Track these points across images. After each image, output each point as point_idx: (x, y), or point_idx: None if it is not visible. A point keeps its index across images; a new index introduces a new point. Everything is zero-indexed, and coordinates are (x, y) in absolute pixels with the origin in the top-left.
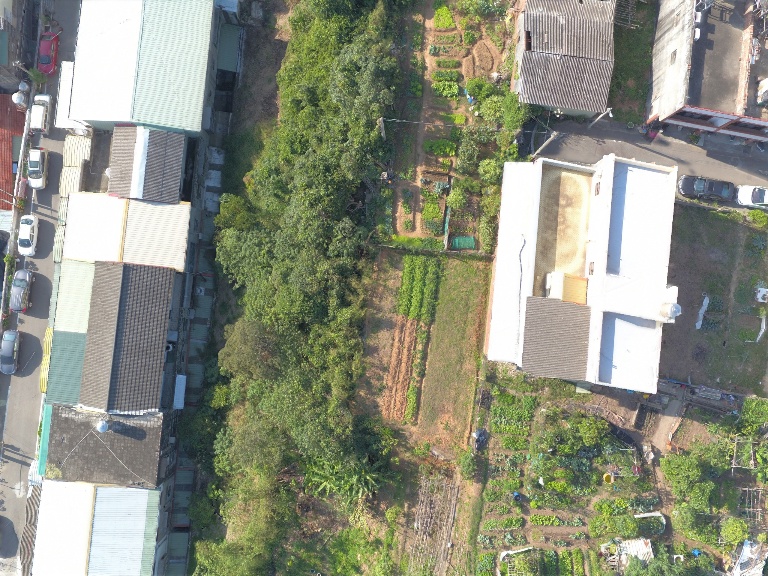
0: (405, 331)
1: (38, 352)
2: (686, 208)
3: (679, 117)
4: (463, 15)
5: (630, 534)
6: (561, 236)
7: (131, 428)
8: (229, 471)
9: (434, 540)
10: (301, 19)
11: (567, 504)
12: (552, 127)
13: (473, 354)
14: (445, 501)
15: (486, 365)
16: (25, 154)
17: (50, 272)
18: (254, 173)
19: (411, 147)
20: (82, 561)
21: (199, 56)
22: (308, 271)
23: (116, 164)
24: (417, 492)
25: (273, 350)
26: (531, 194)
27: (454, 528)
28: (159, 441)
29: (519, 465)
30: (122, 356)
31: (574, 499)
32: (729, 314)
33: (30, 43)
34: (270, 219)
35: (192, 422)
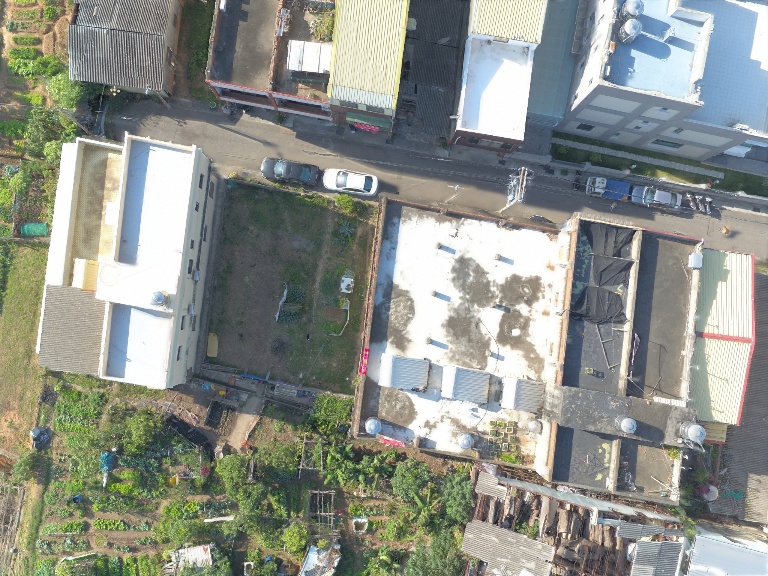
0: None
1: None
2: (271, 193)
3: (238, 95)
4: None
5: (181, 539)
6: None
7: None
8: None
9: None
10: None
11: (130, 507)
12: (129, 107)
13: None
14: (10, 503)
15: None
16: None
17: None
18: None
19: None
20: None
21: None
22: None
23: None
24: None
25: None
26: None
27: (19, 532)
28: None
29: None
30: None
31: (142, 502)
32: (314, 305)
33: None
34: None
35: None
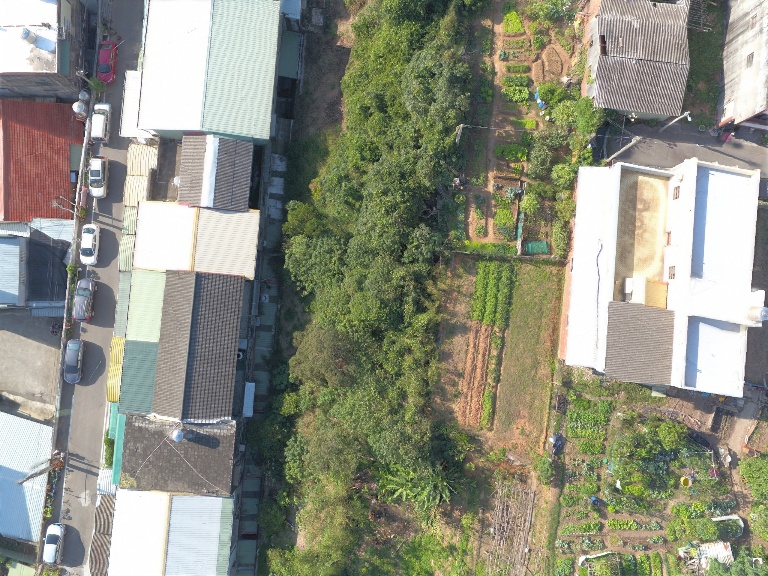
0: (479, 337)
1: (101, 361)
2: (759, 210)
3: (755, 120)
4: (532, 20)
5: (711, 537)
6: (639, 240)
7: (204, 436)
8: (300, 478)
9: (509, 545)
10: (365, 25)
11: (645, 508)
12: None
13: (547, 359)
14: (521, 506)
15: (561, 370)
16: (85, 163)
17: (112, 281)
18: (323, 180)
19: (482, 153)
20: (158, 570)
21: (267, 64)
22: (384, 278)
23: (186, 173)
24: (491, 497)
25: (347, 357)
26: (608, 199)
27: (531, 533)
28: (233, 449)
29: (596, 469)
30: (195, 365)
31: (651, 503)
32: None
33: (87, 52)
34: (339, 226)
35: (262, 430)
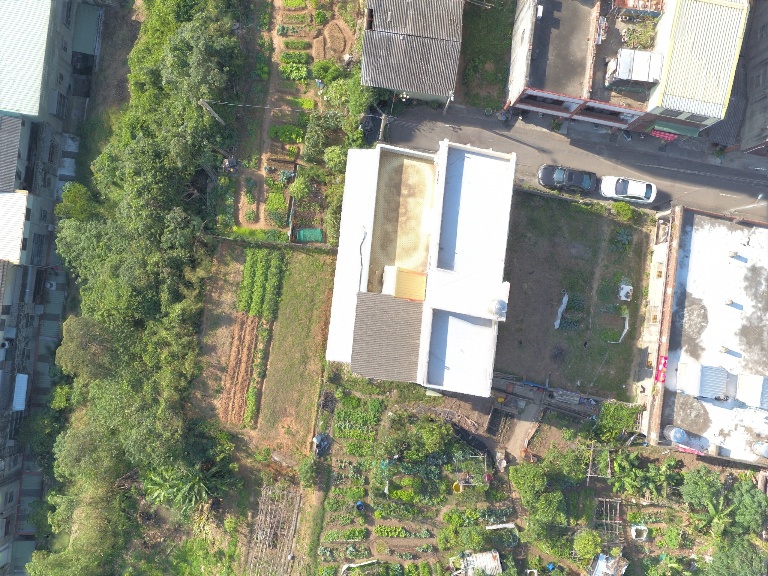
0: (246, 329)
1: None
2: (547, 200)
3: (531, 102)
4: None
5: (475, 547)
6: (402, 228)
7: None
8: (68, 476)
9: None
10: None
11: (413, 514)
12: (404, 113)
13: (318, 354)
14: (286, 510)
15: (330, 365)
16: None
17: None
18: None
19: (255, 133)
20: None
21: (37, 35)
22: (138, 264)
23: None
24: None
25: (105, 348)
26: None
27: (295, 539)
28: None
29: (364, 472)
30: None
31: (422, 509)
32: (591, 313)
33: None
34: None
35: (31, 424)
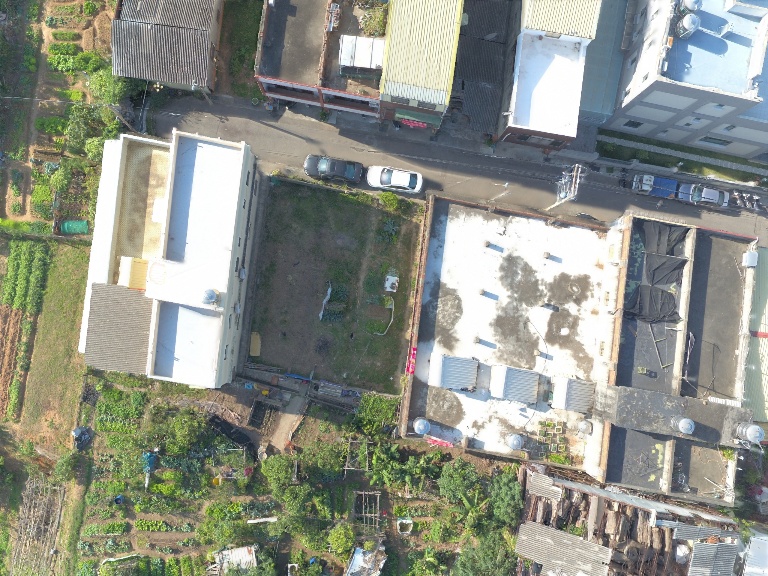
0: (10, 322)
1: None
2: (314, 190)
3: (283, 91)
4: None
5: (226, 541)
6: (150, 219)
7: None
8: None
9: None
10: None
11: (173, 508)
12: (170, 103)
13: None
14: (50, 504)
15: None
16: None
17: None
18: None
19: (22, 125)
20: None
21: None
22: None
23: None
24: None
25: None
26: None
27: (59, 533)
28: None
29: None
30: None
31: (184, 503)
32: (357, 304)
33: None
34: None
35: None
